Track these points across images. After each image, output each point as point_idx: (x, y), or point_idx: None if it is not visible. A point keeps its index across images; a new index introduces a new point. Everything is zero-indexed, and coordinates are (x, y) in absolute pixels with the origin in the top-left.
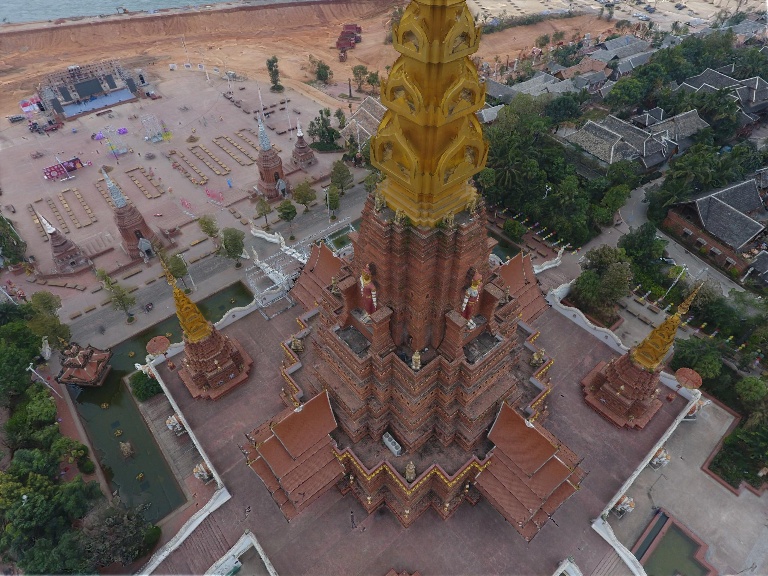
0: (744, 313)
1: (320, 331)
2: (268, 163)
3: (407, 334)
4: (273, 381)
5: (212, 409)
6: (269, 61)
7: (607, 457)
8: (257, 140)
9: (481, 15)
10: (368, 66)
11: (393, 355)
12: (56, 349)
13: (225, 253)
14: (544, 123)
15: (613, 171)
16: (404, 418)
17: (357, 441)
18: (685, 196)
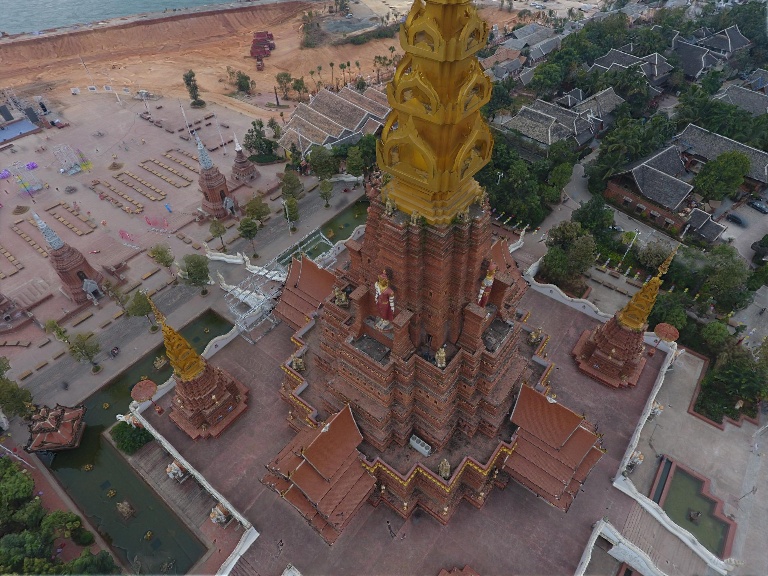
0: (695, 266)
1: (323, 346)
2: (212, 182)
3: (426, 334)
4: (274, 406)
5: (215, 447)
6: (186, 76)
7: (610, 418)
8: (188, 159)
9: (391, 14)
10: (292, 72)
11: (416, 357)
12: (17, 416)
13: (190, 282)
14: (482, 113)
15: (553, 151)
16: (431, 417)
17: (384, 450)
18: (620, 167)
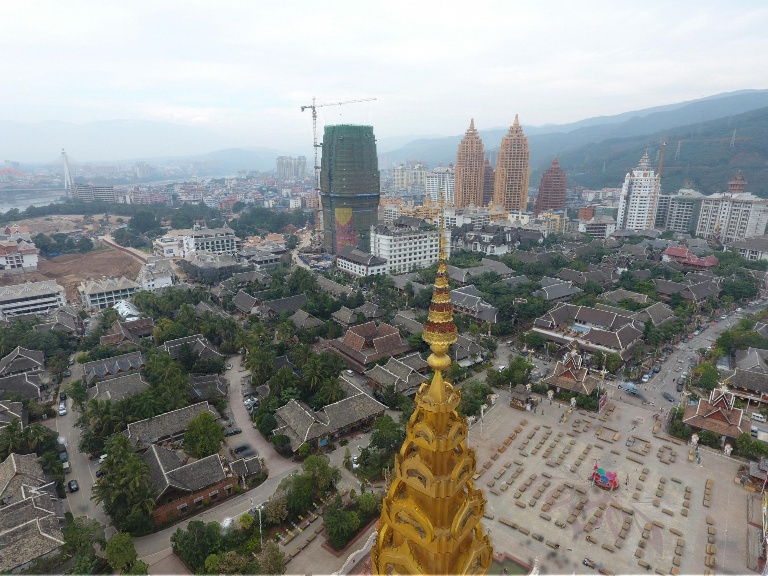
0: (306, 487)
1: None
2: None
3: None
4: None
5: None
6: None
7: None
8: None
9: None
10: None
11: None
12: None
13: None
14: None
15: (78, 544)
16: None
17: None
18: None
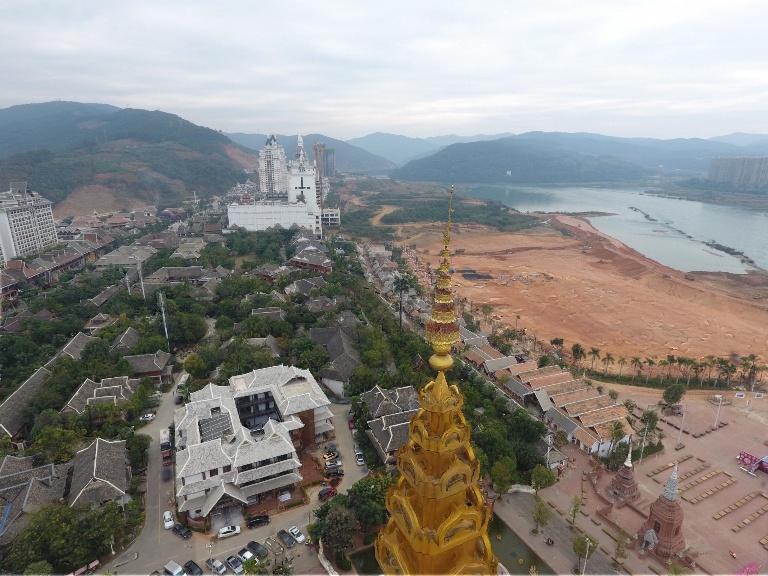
0: None
1: None
2: None
3: None
4: None
5: None
6: None
7: None
8: None
9: None
10: None
11: None
12: (493, 488)
13: None
14: None
15: None
16: None
17: None
18: None
